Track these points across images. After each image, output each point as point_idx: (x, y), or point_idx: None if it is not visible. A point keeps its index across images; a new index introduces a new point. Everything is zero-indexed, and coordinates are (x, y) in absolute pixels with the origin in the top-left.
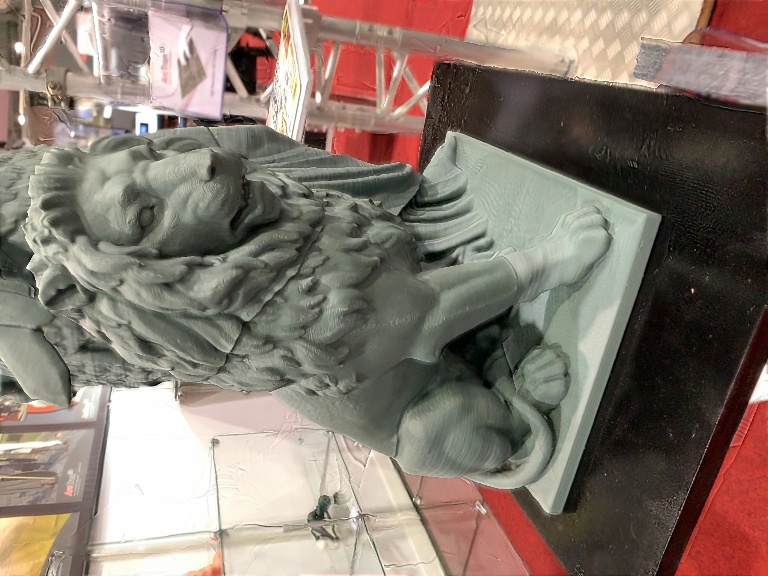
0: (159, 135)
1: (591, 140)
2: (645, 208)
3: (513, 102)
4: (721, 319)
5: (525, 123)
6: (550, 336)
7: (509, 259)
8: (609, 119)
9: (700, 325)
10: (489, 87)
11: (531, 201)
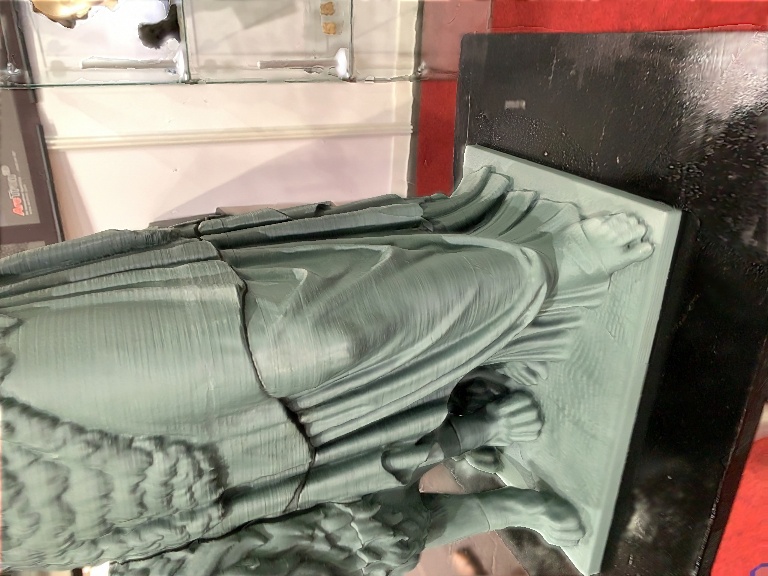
0: (185, 411)
1: (651, 518)
2: (603, 559)
3: (704, 385)
4: None
5: (678, 406)
6: (505, 460)
7: None
8: (667, 548)
9: (552, 572)
10: (735, 320)
11: (585, 443)
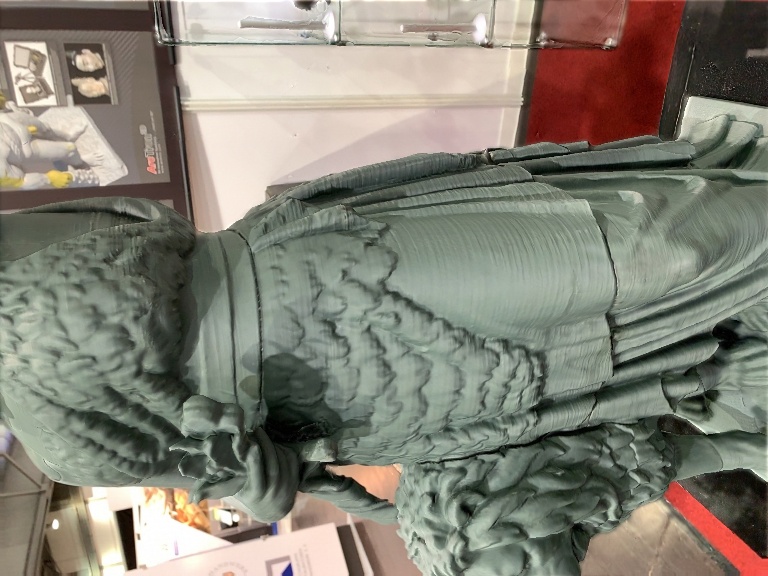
0: (545, 314)
1: None
2: None
3: None
4: (763, 538)
5: None
6: (716, 409)
7: (723, 468)
8: None
9: (758, 521)
10: None
11: None
